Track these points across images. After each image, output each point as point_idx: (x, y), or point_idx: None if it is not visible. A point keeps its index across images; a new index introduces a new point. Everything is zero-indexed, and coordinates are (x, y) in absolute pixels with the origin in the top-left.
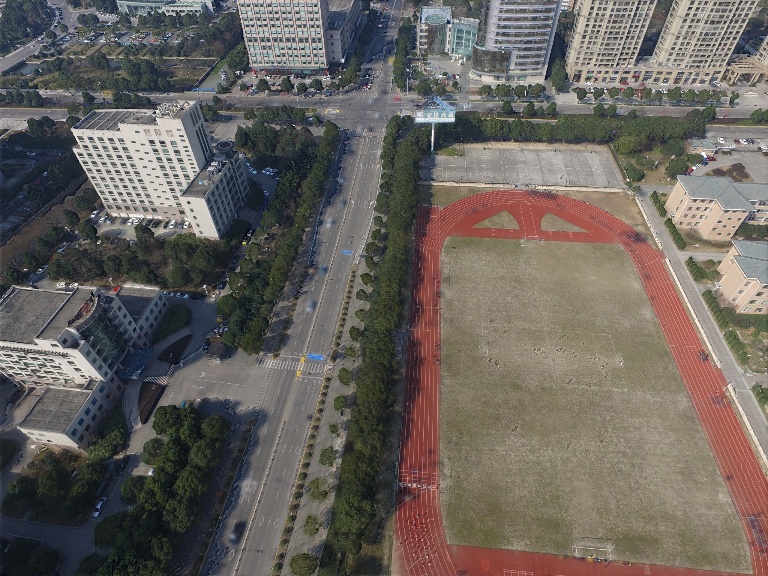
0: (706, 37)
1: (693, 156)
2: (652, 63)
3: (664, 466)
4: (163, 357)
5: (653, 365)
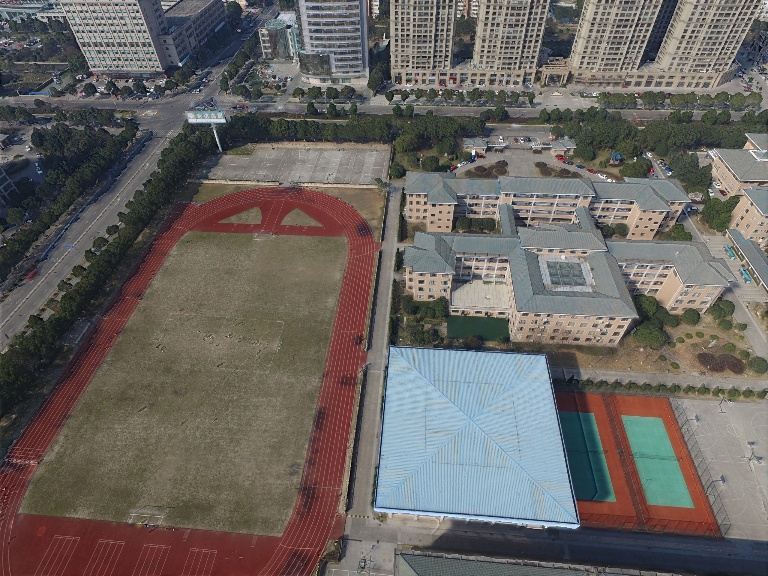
0: (508, 40)
1: (462, 154)
2: (469, 65)
3: (260, 441)
4: None
5: (307, 349)
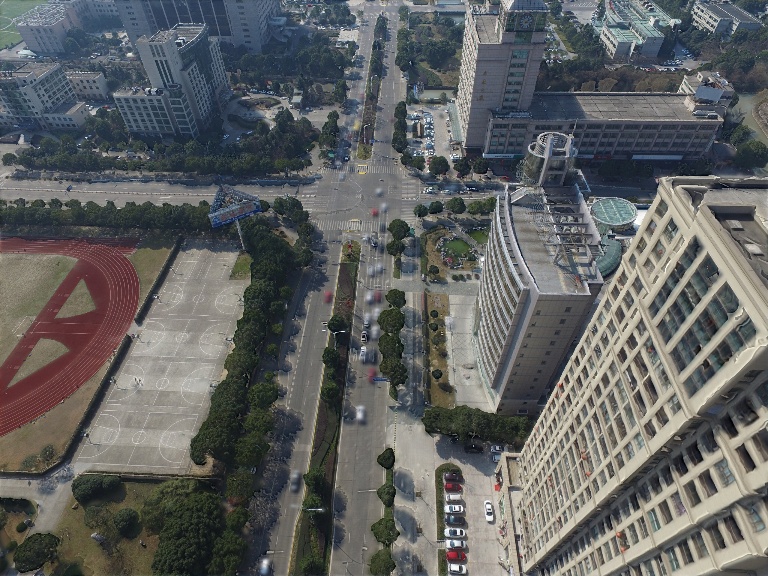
0: None
1: None
2: None
3: None
4: (34, 136)
5: None
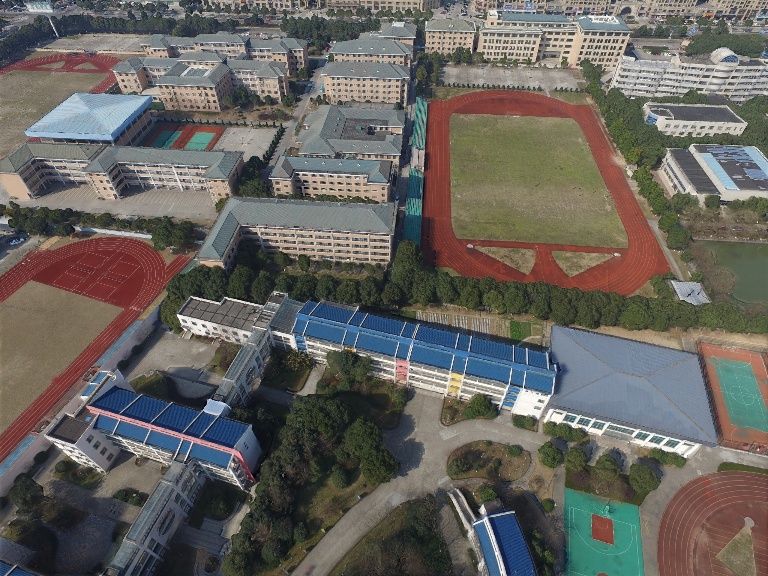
0: None
1: None
2: None
3: None
4: None
5: None
